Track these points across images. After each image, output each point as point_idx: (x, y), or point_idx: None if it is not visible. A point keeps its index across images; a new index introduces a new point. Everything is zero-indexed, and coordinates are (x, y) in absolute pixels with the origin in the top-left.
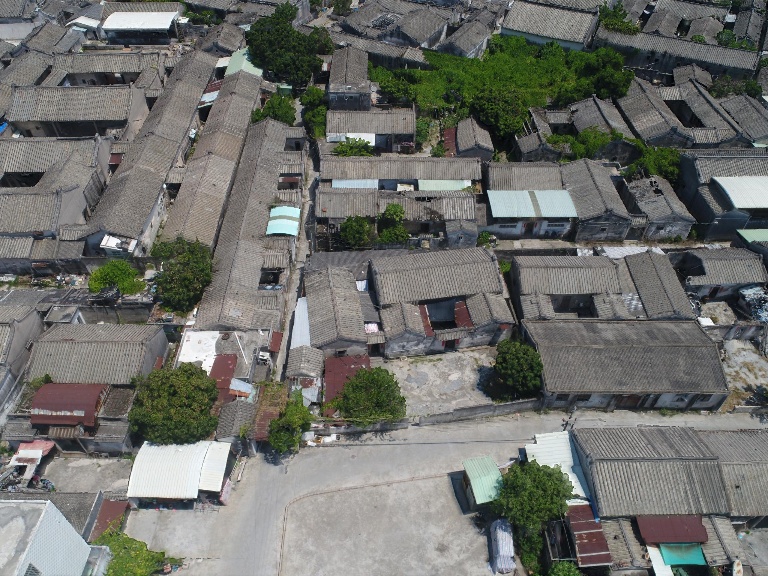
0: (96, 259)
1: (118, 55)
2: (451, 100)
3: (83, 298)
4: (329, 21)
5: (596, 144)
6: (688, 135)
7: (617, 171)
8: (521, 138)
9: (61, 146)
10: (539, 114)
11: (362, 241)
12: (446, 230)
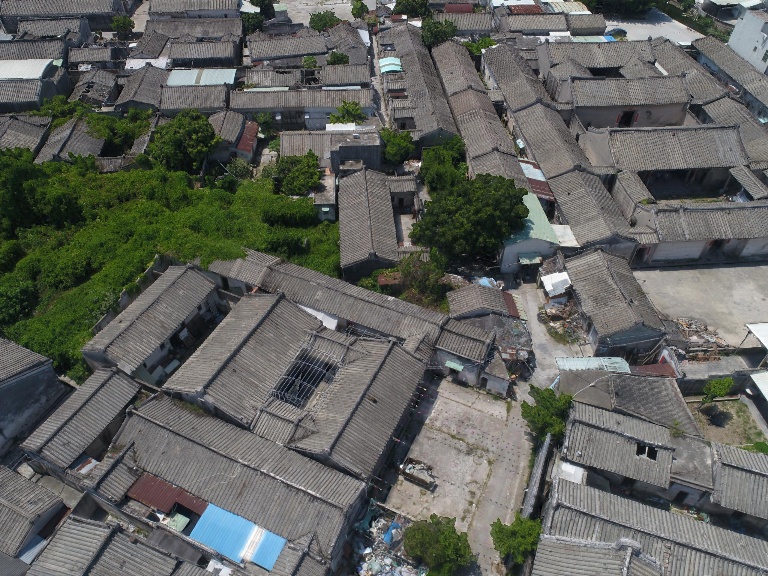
0: None
1: (713, 209)
2: None
3: None
4: (464, 528)
5: (106, 115)
6: None
7: None
8: None
9: None
10: None
11: None
12: None
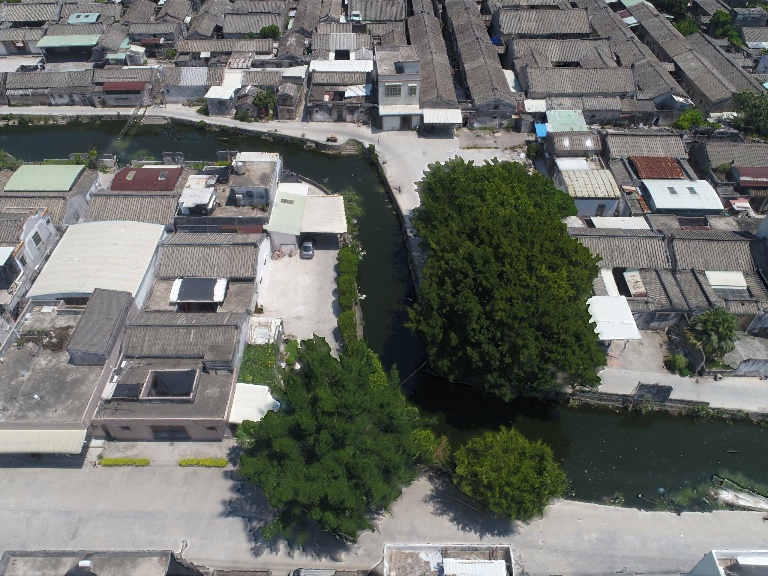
0: (665, 112)
1: None
2: None
3: None
4: None
5: None
6: None
7: None
8: None
9: (584, 44)
10: None
11: None
12: None
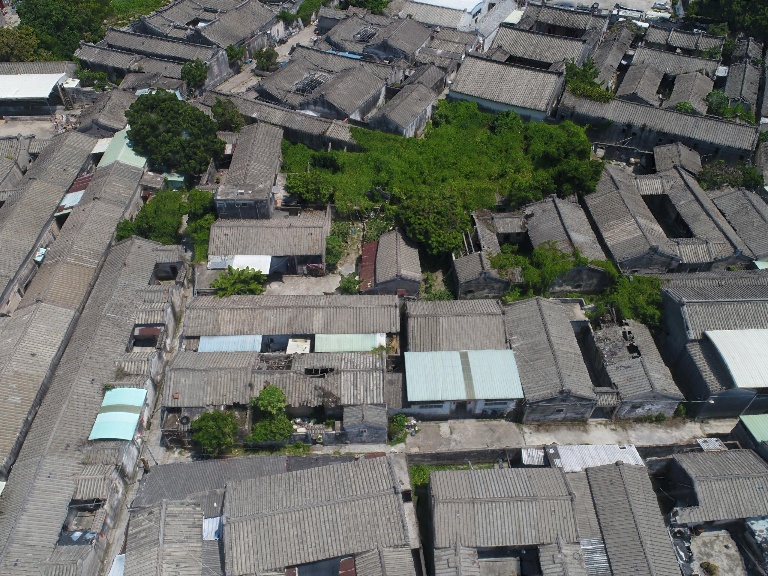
0: None
1: None
2: (377, 199)
3: None
4: (252, 77)
5: (554, 271)
6: (672, 254)
7: (581, 310)
8: (459, 258)
9: None
10: (484, 221)
11: (223, 445)
12: (343, 422)
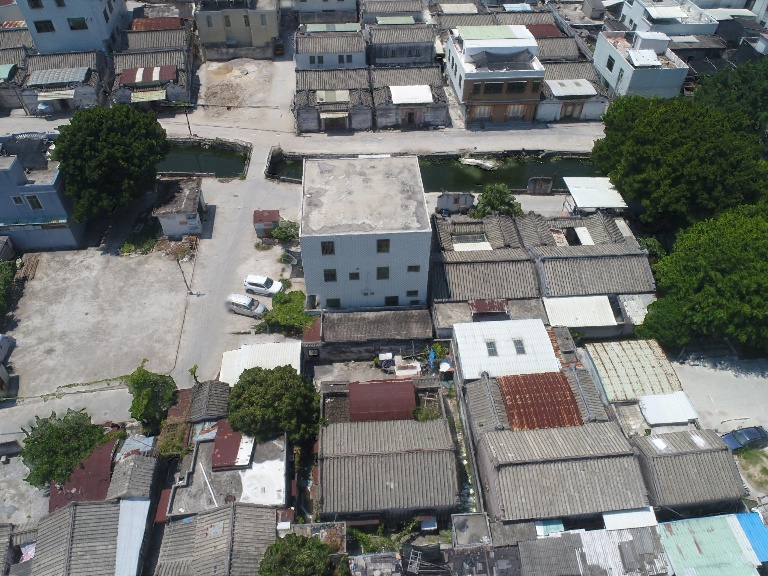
0: None
1: None
2: None
3: (462, 569)
4: None
5: None
6: None
7: None
8: None
9: None
10: None
11: None
12: None
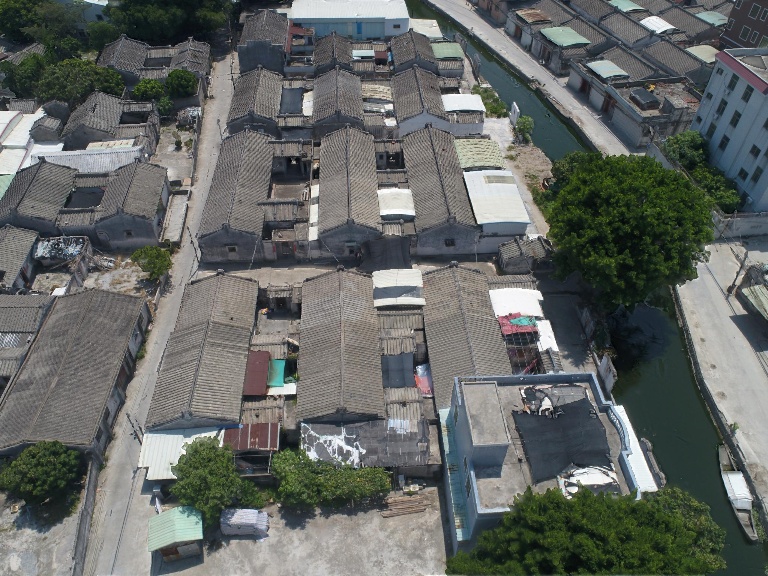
0: None
1: None
2: None
3: None
4: None
5: None
6: None
7: None
8: None
9: None
10: None
11: None
12: None
